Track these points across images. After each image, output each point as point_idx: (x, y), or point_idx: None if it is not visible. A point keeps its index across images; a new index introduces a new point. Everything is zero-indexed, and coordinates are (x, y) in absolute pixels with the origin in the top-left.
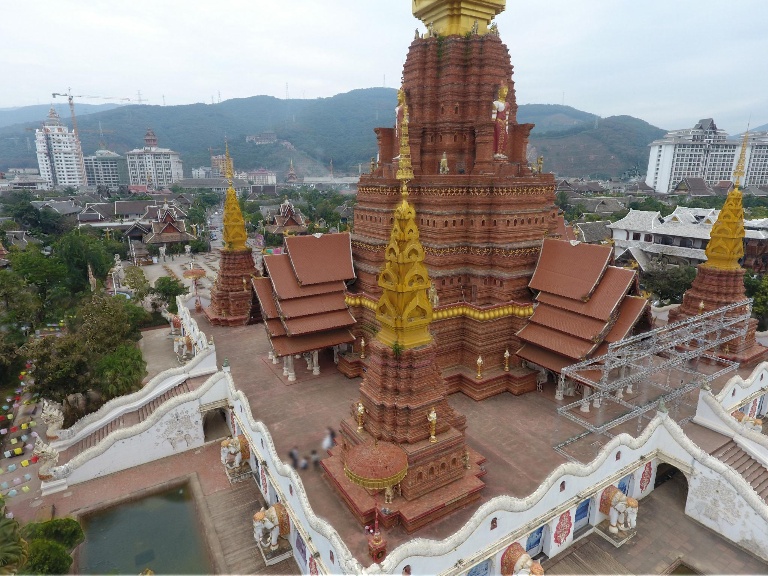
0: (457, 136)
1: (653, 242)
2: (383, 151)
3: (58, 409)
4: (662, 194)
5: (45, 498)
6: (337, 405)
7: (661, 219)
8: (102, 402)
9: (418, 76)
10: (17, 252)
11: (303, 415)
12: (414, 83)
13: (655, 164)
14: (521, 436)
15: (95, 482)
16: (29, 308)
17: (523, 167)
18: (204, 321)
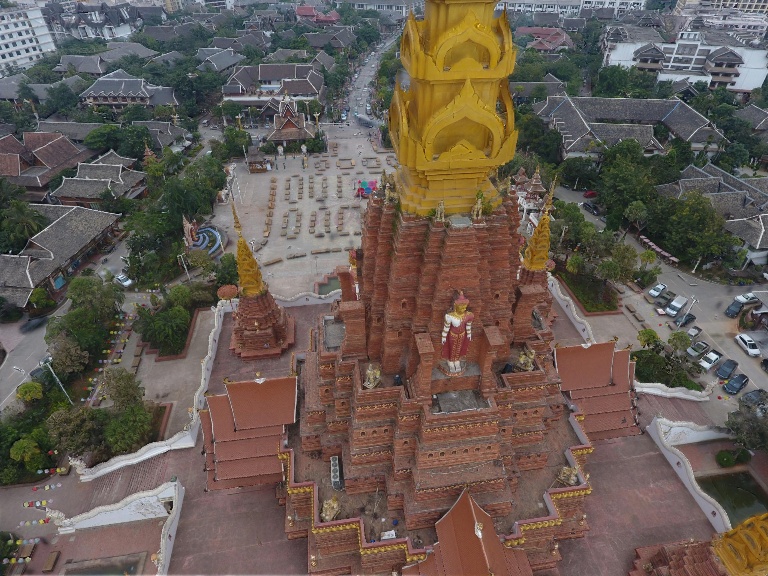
0: (403, 331)
1: None
2: (344, 293)
3: (80, 459)
4: None
5: (60, 537)
6: (245, 548)
7: None
8: (112, 453)
9: (367, 247)
10: (152, 164)
11: (213, 552)
12: None
13: None
14: None
15: (91, 531)
16: (106, 305)
17: (483, 380)
18: None
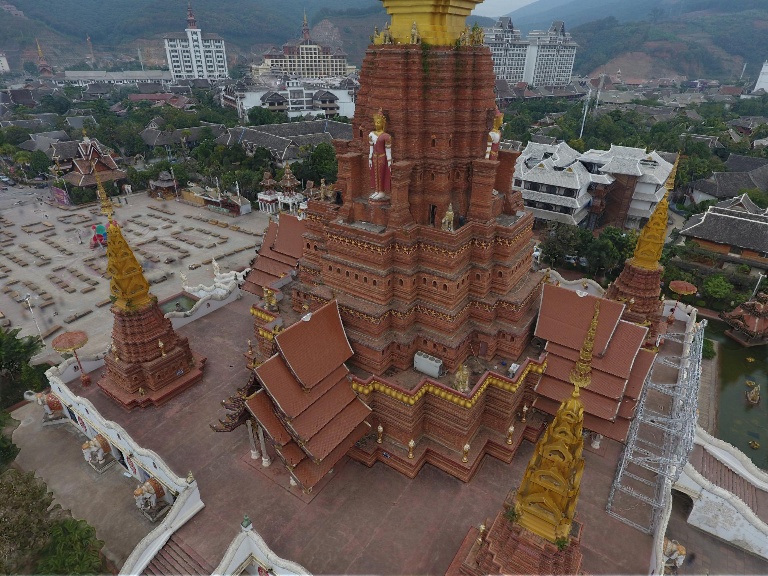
0: (450, 173)
1: (524, 188)
2: (353, 185)
3: None
4: None
5: None
6: (386, 519)
7: (526, 162)
8: None
9: (402, 97)
10: None
11: (362, 551)
12: (395, 105)
13: None
14: None
15: None
16: None
17: (509, 198)
18: (109, 403)
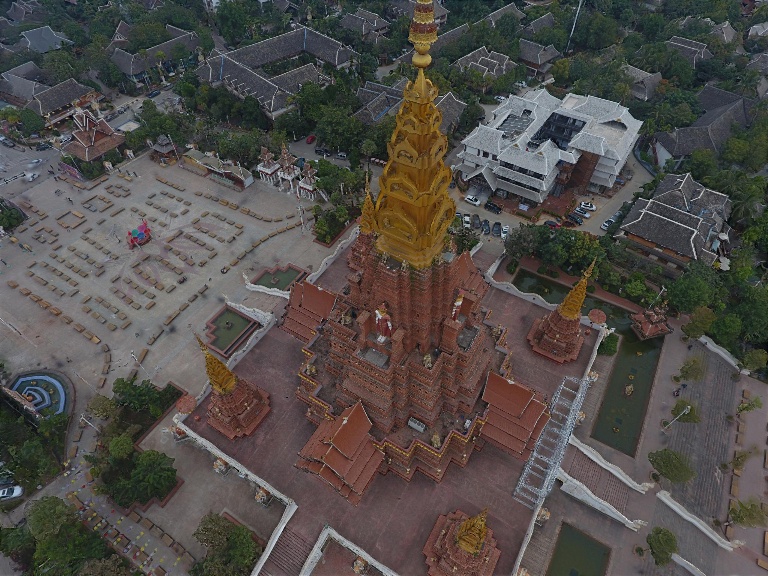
0: None
1: (500, 165)
2: None
3: None
4: None
5: None
6: (396, 509)
7: (504, 135)
8: None
9: (397, 299)
10: None
11: (385, 529)
12: (393, 300)
13: None
14: (496, 493)
15: None
16: (75, 513)
17: (469, 319)
18: (219, 435)
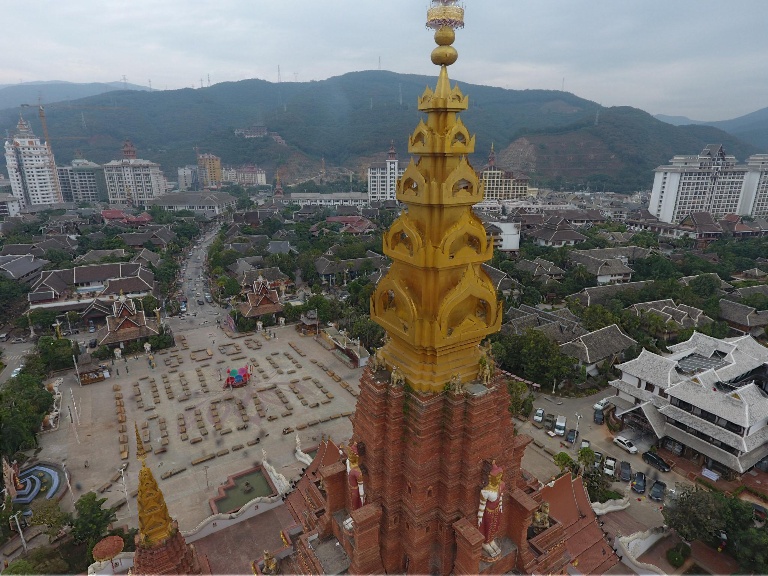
0: (430, 525)
1: None
2: (331, 500)
3: None
4: (666, 227)
5: None
6: None
7: (678, 368)
8: None
9: (375, 439)
10: None
11: None
12: (370, 442)
13: (659, 191)
14: None
15: None
16: None
17: (522, 554)
18: None
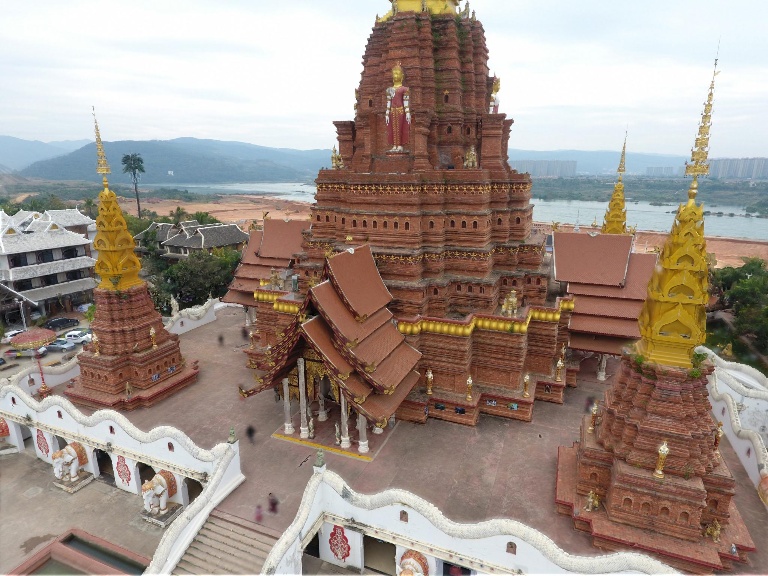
0: None
1: (9, 267)
2: None
3: None
4: None
5: None
6: None
7: None
8: None
9: None
10: None
11: None
12: None
13: None
14: None
15: None
16: None
17: None
18: None
